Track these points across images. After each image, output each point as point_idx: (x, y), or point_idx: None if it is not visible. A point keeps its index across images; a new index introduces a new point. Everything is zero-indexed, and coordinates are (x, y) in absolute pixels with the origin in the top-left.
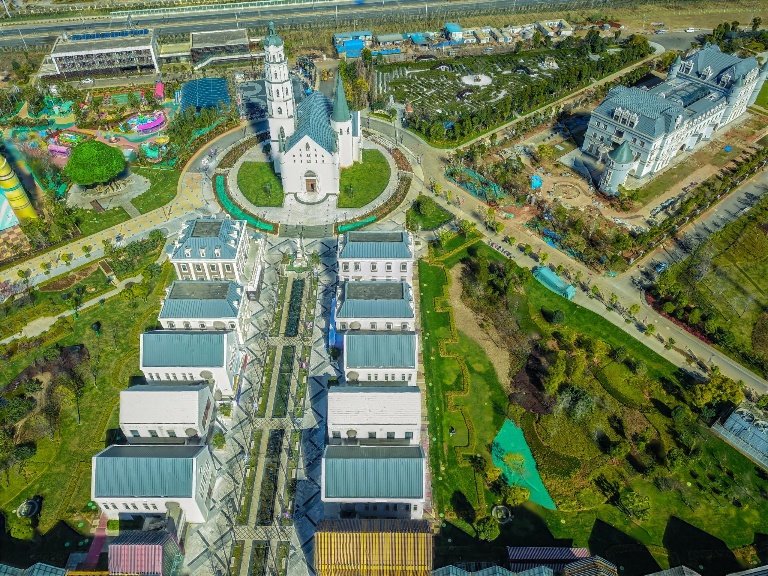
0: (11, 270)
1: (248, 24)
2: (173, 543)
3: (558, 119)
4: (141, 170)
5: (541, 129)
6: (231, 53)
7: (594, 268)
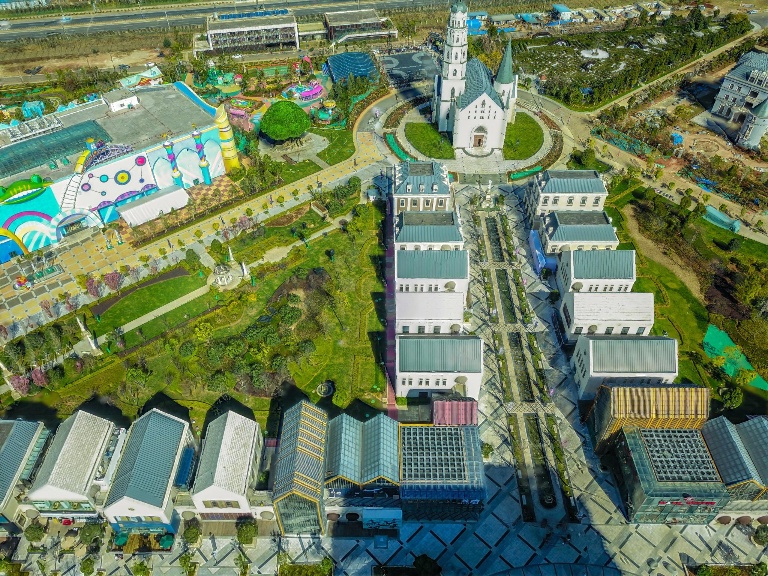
0: (234, 210)
1: (363, 7)
2: None
3: (681, 86)
4: (316, 130)
5: (667, 95)
6: (365, 31)
7: (750, 208)
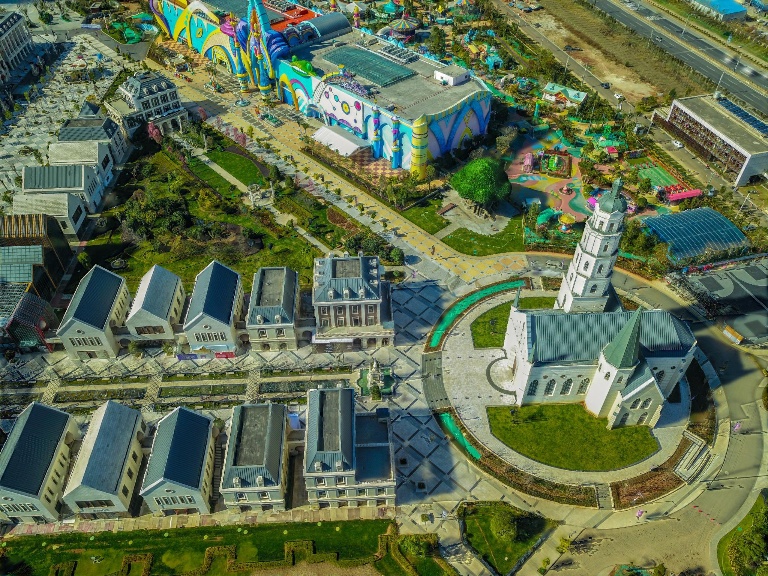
0: (353, 188)
1: None
2: (37, 334)
3: None
4: (517, 222)
5: None
6: None
7: None
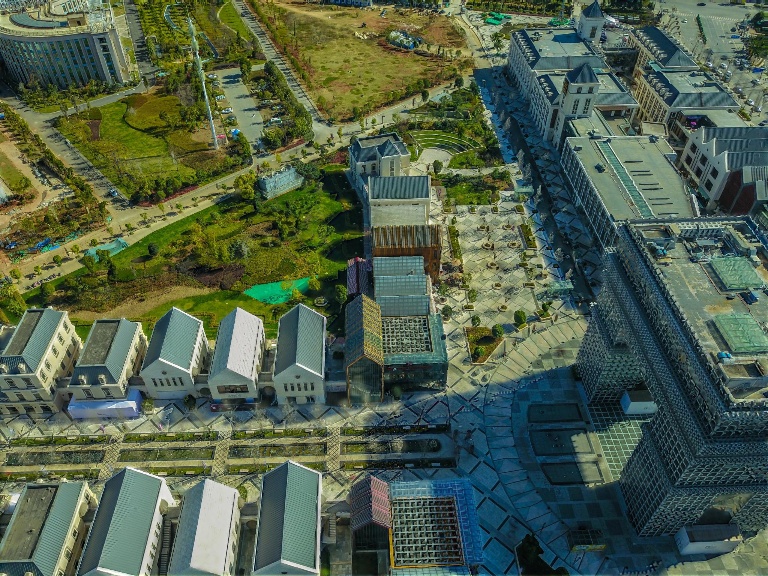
0: None
1: None
2: None
3: None
4: None
5: None
6: None
7: (98, 227)
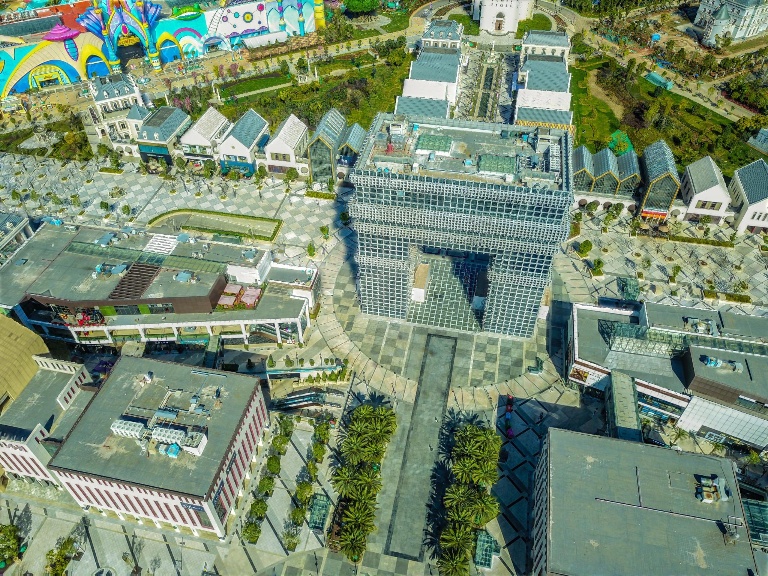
0: (316, 50)
1: None
2: None
3: (679, 8)
4: (384, 14)
5: (665, 12)
6: None
7: (688, 78)
